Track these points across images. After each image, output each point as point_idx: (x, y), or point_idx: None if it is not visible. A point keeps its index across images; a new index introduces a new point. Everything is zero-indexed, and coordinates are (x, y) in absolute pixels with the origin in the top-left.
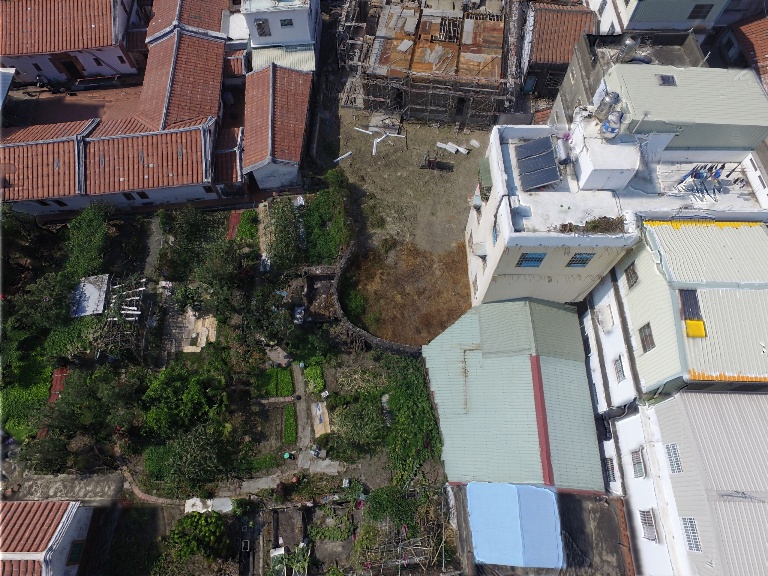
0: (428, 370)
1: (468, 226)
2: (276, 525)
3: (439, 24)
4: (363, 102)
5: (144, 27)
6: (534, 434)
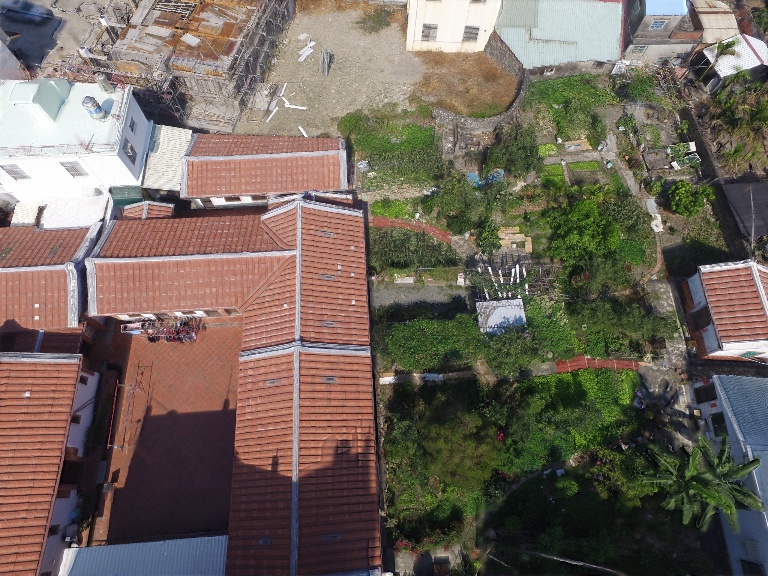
0: (543, 66)
1: (411, 35)
2: (658, 169)
3: (163, 12)
4: (238, 105)
5: (28, 342)
6: (593, 3)
